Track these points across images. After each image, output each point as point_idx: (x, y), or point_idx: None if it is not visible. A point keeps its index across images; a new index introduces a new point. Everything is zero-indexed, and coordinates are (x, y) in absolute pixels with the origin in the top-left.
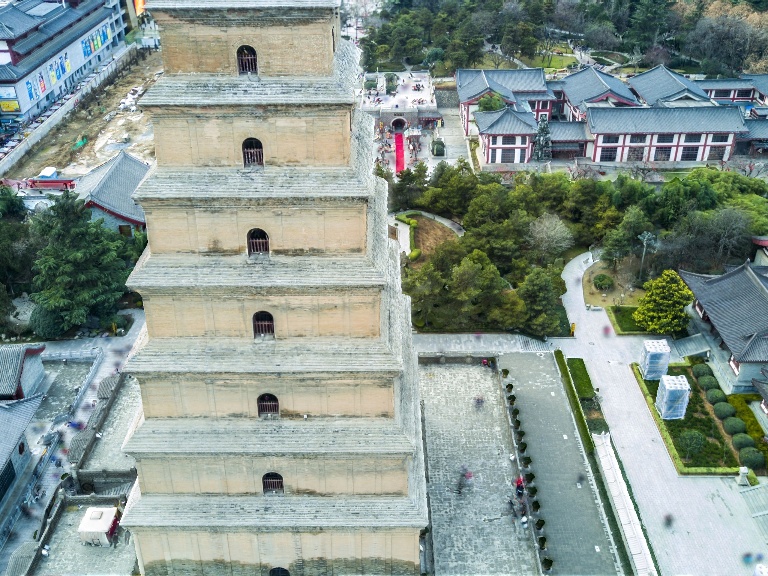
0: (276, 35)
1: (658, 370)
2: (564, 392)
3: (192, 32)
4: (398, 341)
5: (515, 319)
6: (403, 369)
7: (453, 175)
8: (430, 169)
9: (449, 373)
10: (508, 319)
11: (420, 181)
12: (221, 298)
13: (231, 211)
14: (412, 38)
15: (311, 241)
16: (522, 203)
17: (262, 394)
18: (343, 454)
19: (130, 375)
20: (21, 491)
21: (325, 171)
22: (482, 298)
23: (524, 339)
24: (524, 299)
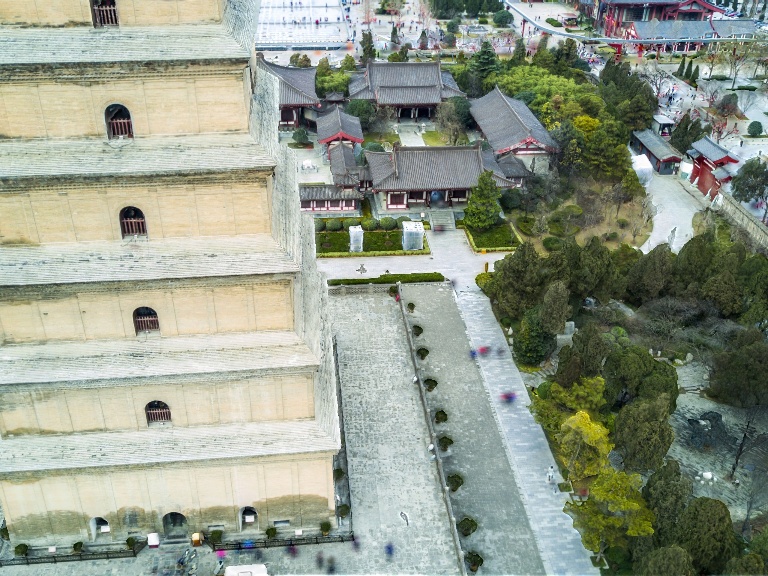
0: None
1: None
2: None
3: None
4: None
5: None
6: None
7: None
8: None
9: None
10: None
11: None
12: None
13: None
14: None
15: None
16: None
17: None
18: None
19: None
20: None
21: None
22: None
23: None
24: None
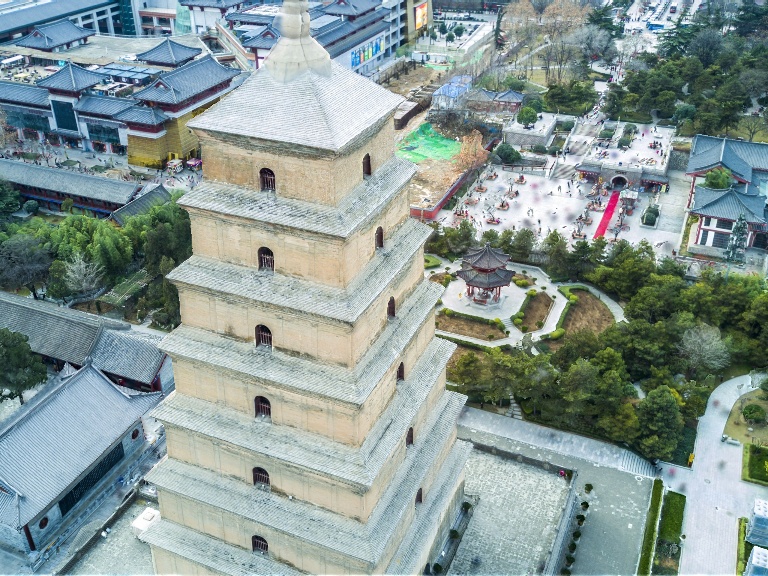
0: (291, 164)
1: (764, 536)
2: (643, 528)
3: (225, 150)
4: (383, 454)
5: (623, 433)
6: (370, 484)
7: (628, 257)
8: (609, 245)
9: (521, 474)
10: (616, 431)
11: (595, 256)
12: (230, 376)
13: (243, 306)
14: (666, 90)
15: (306, 347)
16: (692, 304)
17: (256, 467)
18: (314, 542)
19: (156, 419)
20: (125, 470)
21: (323, 289)
22: (598, 401)
23: (630, 456)
24: (643, 414)
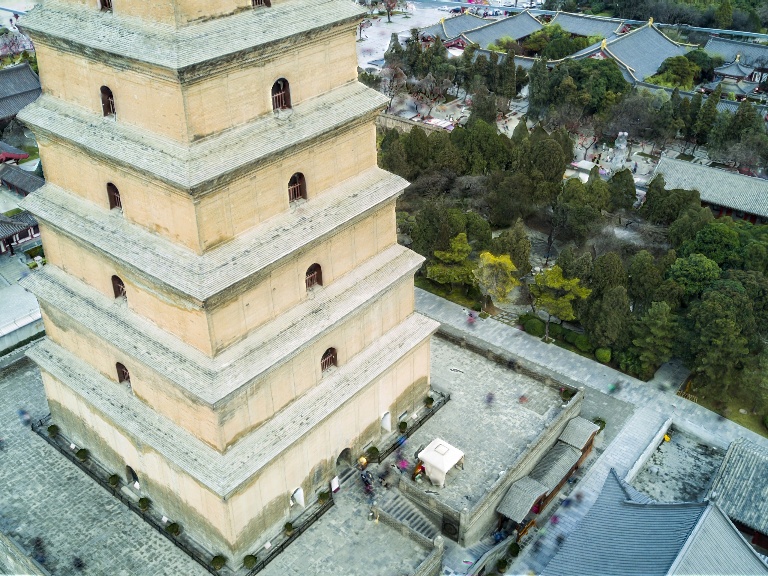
0: None
1: None
2: None
3: None
4: None
5: None
6: None
7: None
8: None
9: None
10: None
11: None
12: None
13: None
14: None
15: None
16: None
17: None
18: None
19: None
20: None
21: None
22: None
23: None
24: None
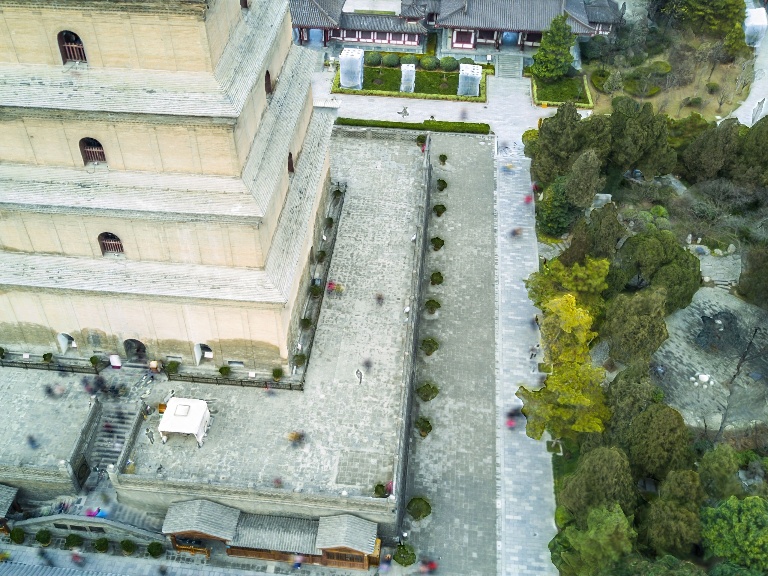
0: None
1: None
2: None
3: None
4: None
5: None
6: None
7: None
8: None
9: None
10: None
11: None
12: None
13: None
14: None
15: None
16: None
17: None
18: None
19: (235, 121)
20: None
21: None
22: None
23: None
24: None
